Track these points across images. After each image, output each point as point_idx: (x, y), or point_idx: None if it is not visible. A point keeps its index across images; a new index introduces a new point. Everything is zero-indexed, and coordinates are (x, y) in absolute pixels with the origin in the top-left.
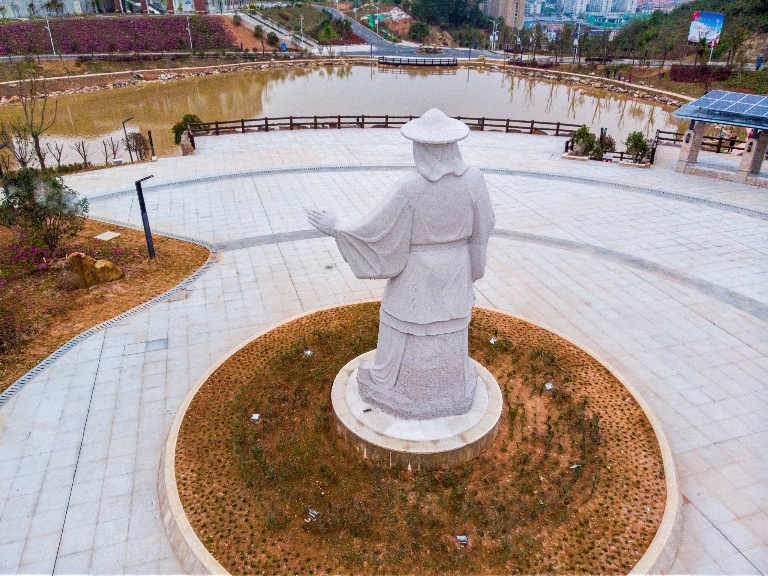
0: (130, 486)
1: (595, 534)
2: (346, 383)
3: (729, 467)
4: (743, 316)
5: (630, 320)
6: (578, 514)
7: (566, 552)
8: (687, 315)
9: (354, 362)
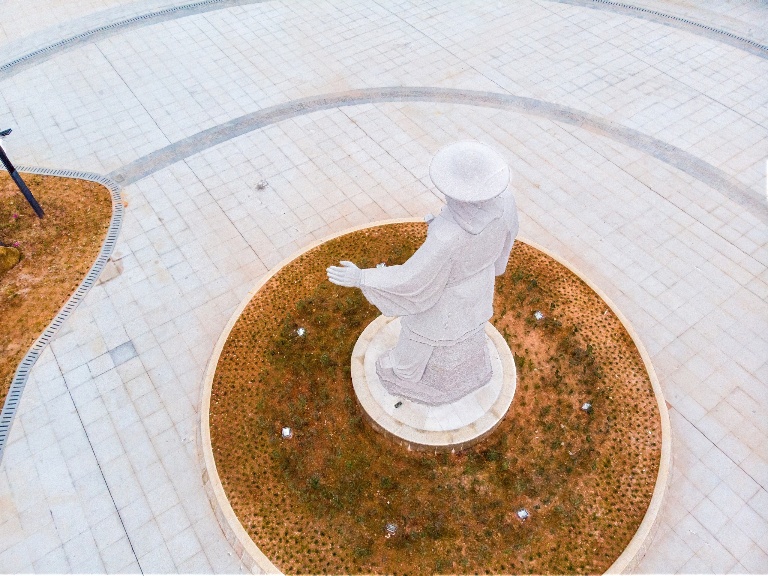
0: (196, 543)
1: (618, 472)
2: (364, 375)
3: (693, 360)
4: (672, 172)
5: (579, 200)
6: (601, 456)
7: (602, 497)
8: (626, 182)
9: (360, 344)
